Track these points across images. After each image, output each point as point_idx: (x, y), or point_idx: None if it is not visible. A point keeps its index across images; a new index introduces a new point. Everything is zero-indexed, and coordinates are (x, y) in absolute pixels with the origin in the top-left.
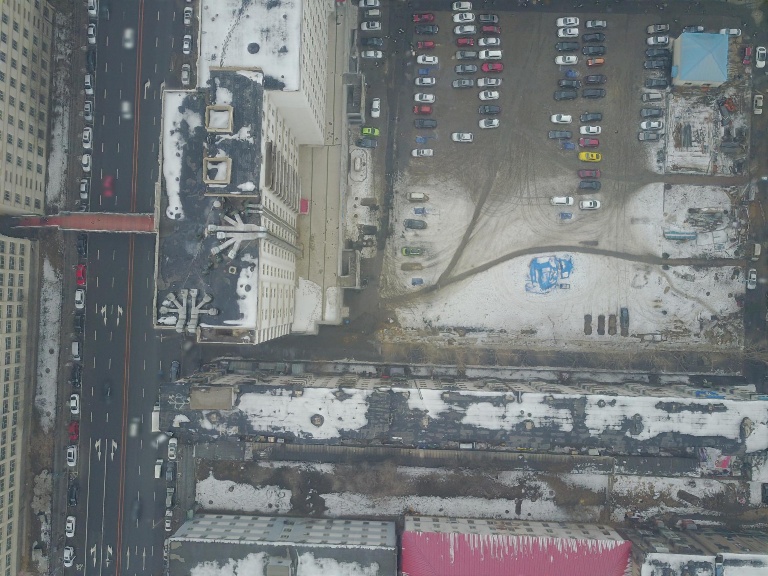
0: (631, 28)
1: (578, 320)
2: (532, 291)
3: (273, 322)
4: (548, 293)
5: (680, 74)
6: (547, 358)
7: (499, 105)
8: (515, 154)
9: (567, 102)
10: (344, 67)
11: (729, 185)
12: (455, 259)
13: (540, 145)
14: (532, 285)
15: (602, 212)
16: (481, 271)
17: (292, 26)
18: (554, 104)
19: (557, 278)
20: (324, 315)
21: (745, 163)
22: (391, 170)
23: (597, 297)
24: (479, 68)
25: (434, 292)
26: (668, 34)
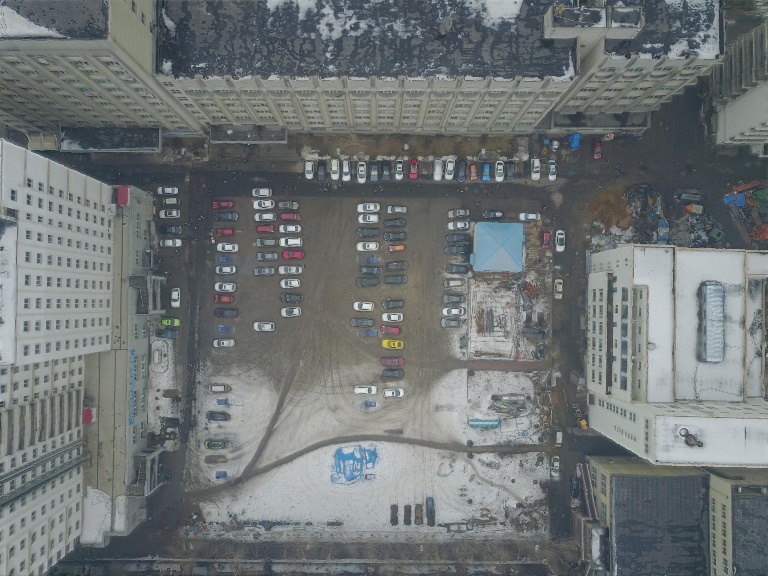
0: (432, 212)
1: (384, 510)
2: (337, 482)
3: (21, 575)
4: (354, 484)
5: (476, 264)
6: (354, 550)
7: (301, 292)
8: (318, 342)
9: (370, 288)
10: (129, 270)
11: (532, 370)
12: (259, 451)
13: (343, 332)
14: (337, 476)
15: (406, 400)
16: (286, 462)
17: (8, 296)
18: (357, 290)
19: (362, 468)
20: (113, 525)
21: (547, 348)
22: (193, 360)
23: (403, 486)
24: (280, 255)
25: (239, 485)
26: (469, 218)
